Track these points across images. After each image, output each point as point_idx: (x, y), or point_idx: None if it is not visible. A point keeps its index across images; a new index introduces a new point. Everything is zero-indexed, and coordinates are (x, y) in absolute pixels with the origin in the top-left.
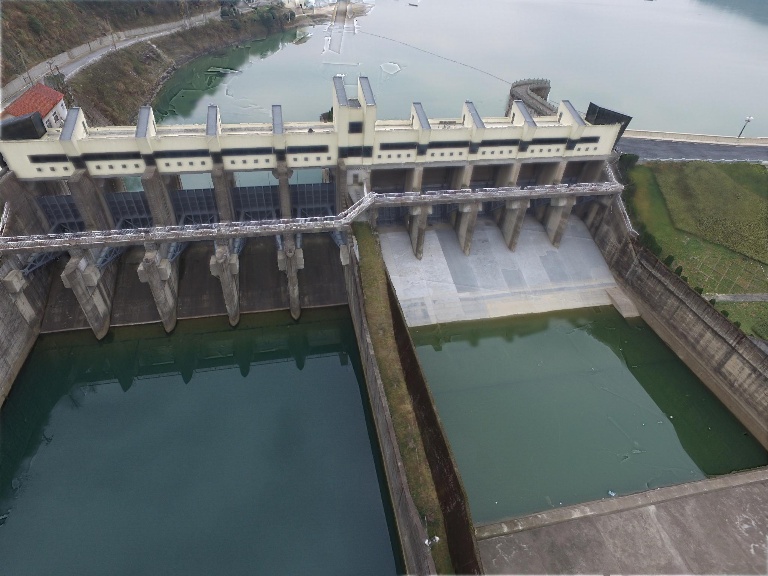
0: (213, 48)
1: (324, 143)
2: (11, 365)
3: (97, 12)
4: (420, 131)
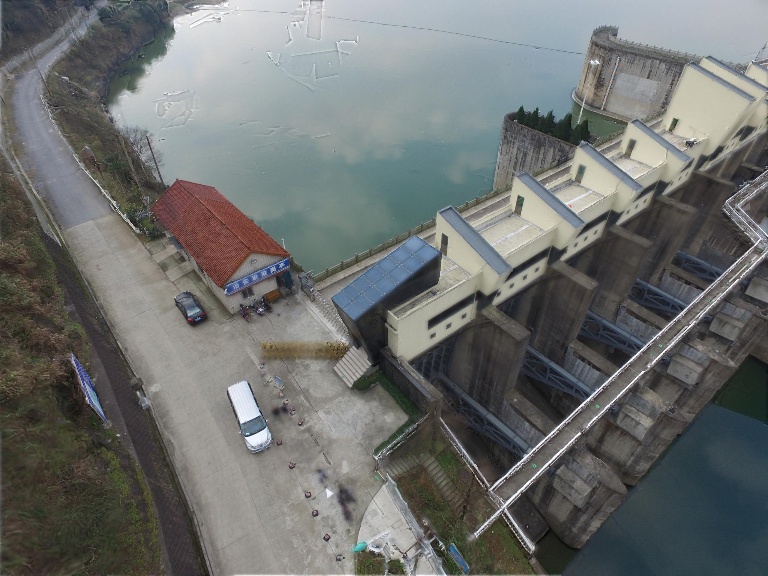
0: (115, 65)
1: (693, 156)
2: None
3: None
4: (761, 111)
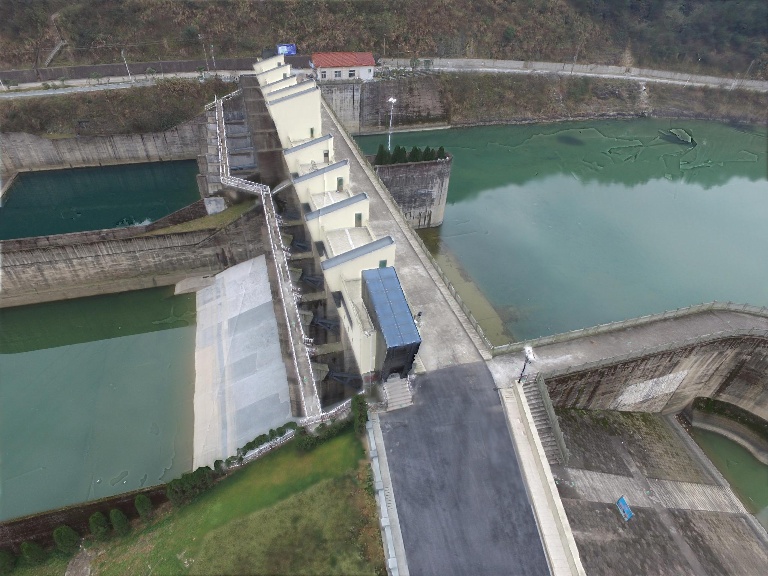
0: (747, 120)
1: None
2: (186, 152)
3: (633, 46)
4: None
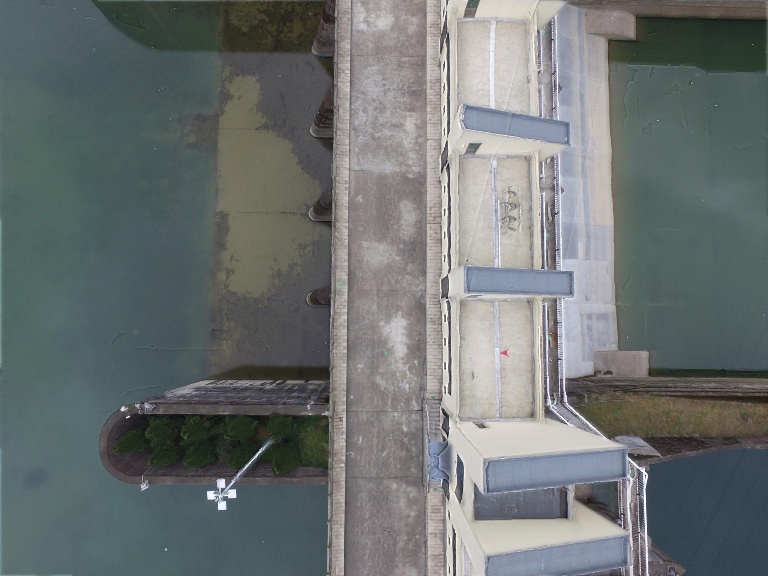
0: None
1: None
2: None
3: None
4: None
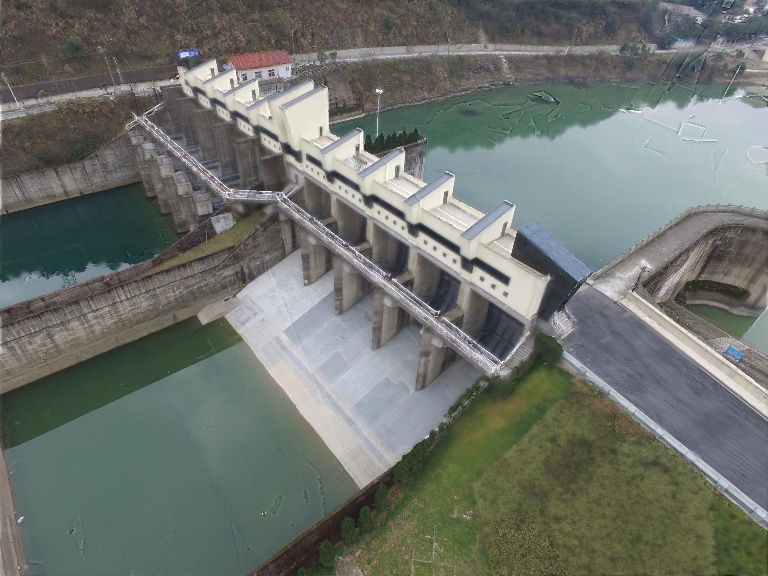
0: (581, 78)
1: None
2: (110, 181)
3: (485, 25)
4: None
